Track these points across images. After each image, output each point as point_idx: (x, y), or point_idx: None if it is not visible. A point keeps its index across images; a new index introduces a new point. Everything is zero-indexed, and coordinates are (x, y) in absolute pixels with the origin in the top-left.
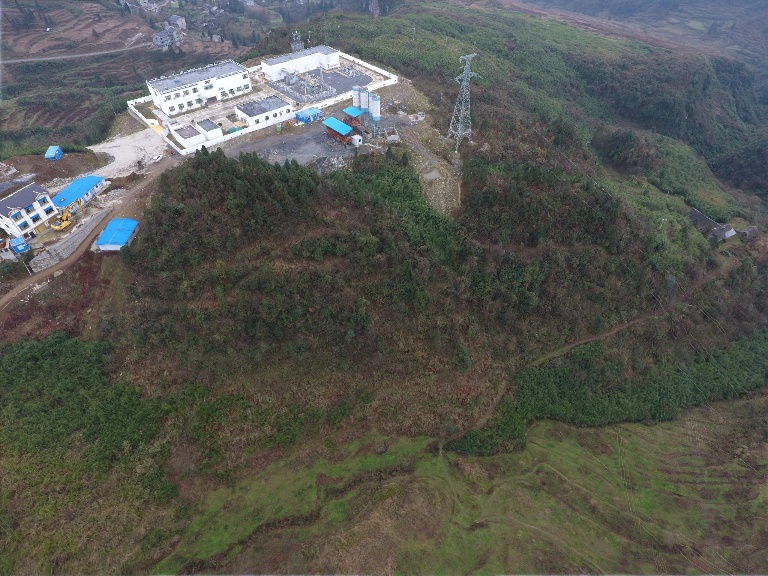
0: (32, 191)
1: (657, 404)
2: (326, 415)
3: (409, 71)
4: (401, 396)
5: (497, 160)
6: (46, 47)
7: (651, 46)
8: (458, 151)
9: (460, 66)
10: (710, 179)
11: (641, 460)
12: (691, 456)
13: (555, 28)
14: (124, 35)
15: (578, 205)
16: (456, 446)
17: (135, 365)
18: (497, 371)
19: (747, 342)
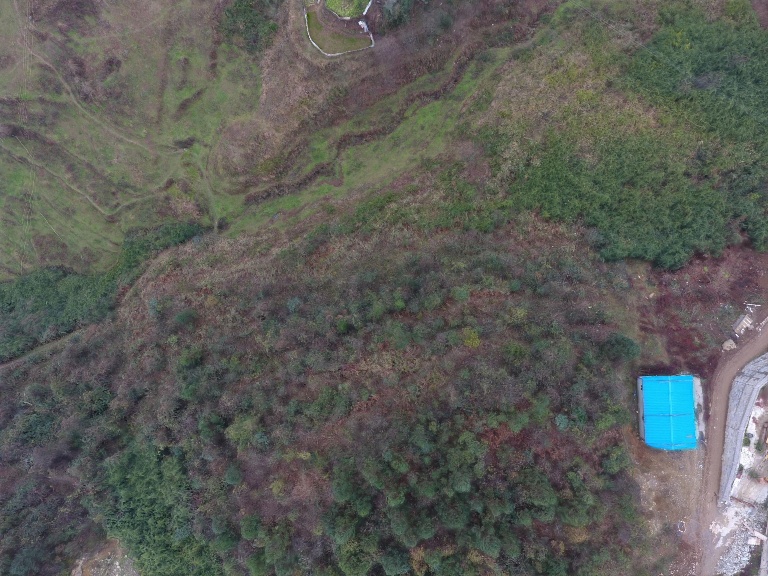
0: None
1: None
2: None
3: None
4: None
5: None
6: None
7: None
8: None
9: None
10: None
11: (6, 231)
12: None
13: None
14: None
15: None
16: (199, 231)
17: None
18: None
19: None
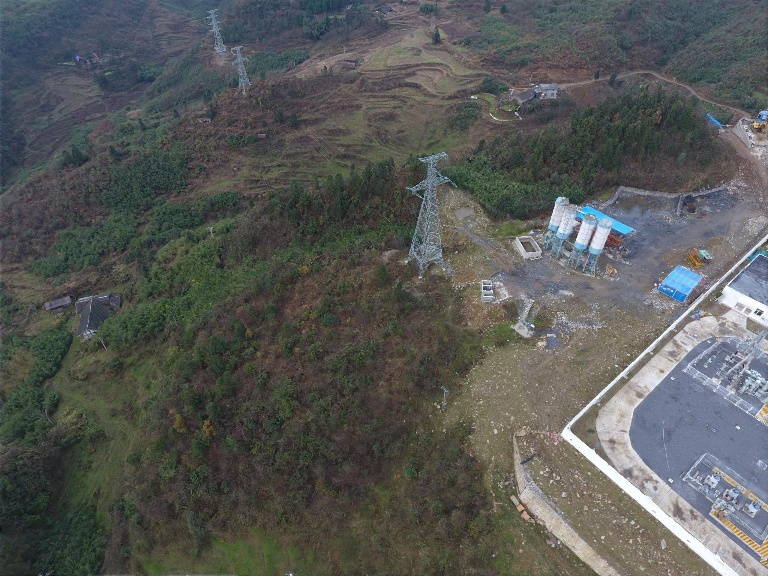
0: None
1: None
2: None
3: None
4: None
5: None
6: None
7: None
8: None
9: None
10: None
11: None
12: None
13: None
14: None
15: None
16: None
17: None
18: None
19: None
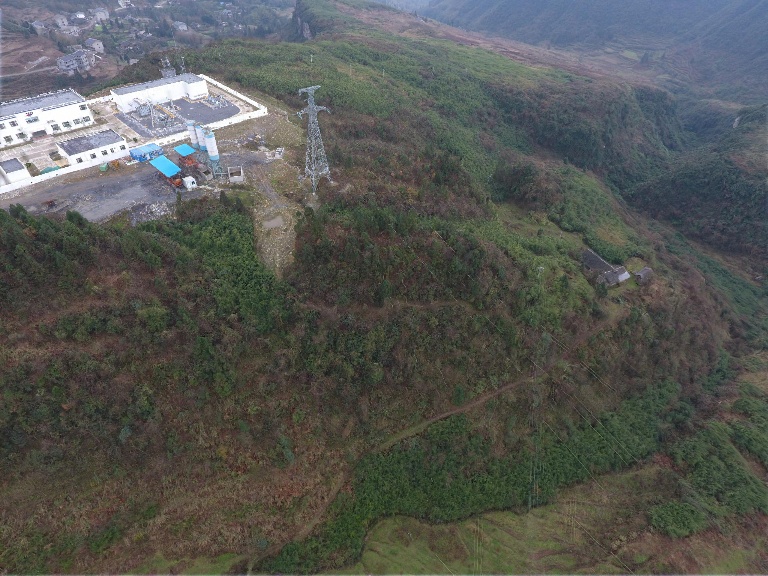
0: None
1: (529, 487)
2: (85, 543)
3: (293, 101)
4: (199, 505)
5: (357, 203)
6: None
7: (573, 75)
8: (316, 193)
9: (355, 96)
10: (615, 214)
11: (501, 565)
12: (561, 555)
13: (479, 56)
14: (25, 58)
15: (434, 257)
16: (270, 564)
17: None
18: (332, 461)
19: (639, 400)
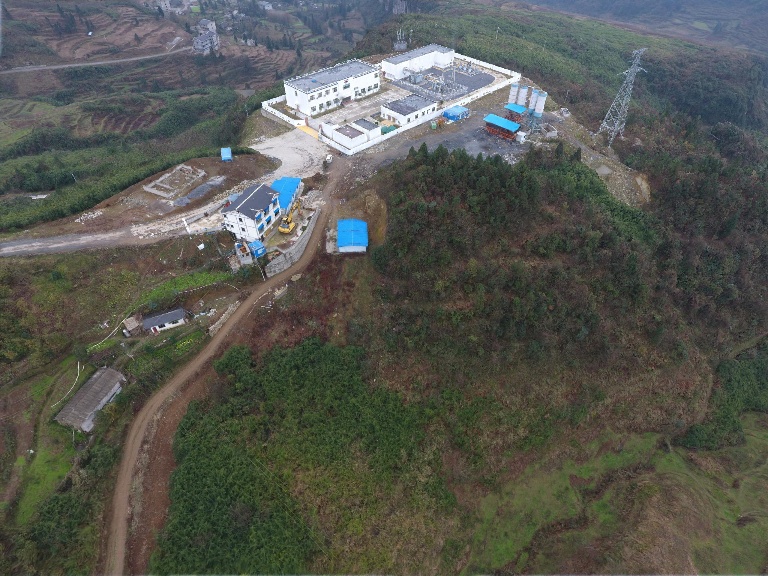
0: (265, 192)
1: None
2: (570, 415)
3: (513, 69)
4: (628, 393)
5: (654, 154)
6: (90, 52)
7: (695, 45)
8: (611, 146)
9: (554, 64)
10: None
11: None
12: None
13: (600, 28)
14: (163, 39)
15: (760, 196)
16: (683, 441)
17: (386, 370)
18: (704, 364)
19: None
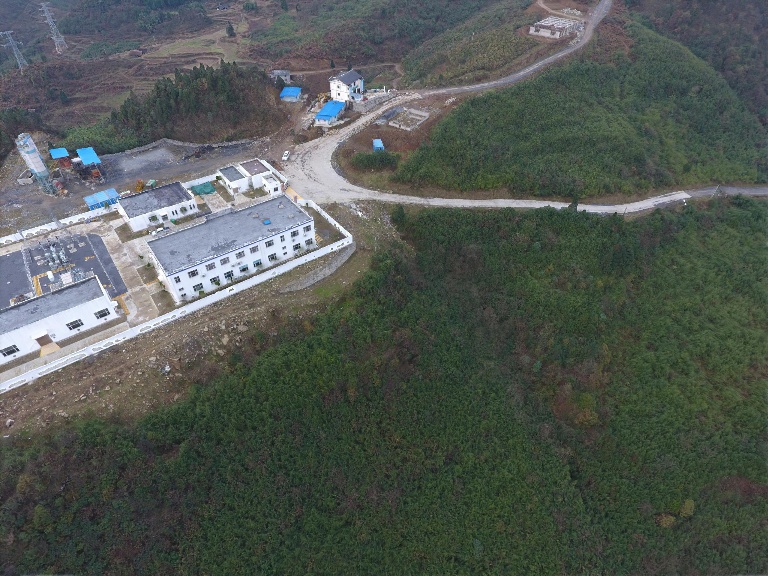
0: None
1: None
2: None
3: None
4: None
5: None
6: None
7: None
8: None
9: None
10: None
11: None
12: None
13: None
14: None
15: None
16: None
17: None
18: None
19: None
